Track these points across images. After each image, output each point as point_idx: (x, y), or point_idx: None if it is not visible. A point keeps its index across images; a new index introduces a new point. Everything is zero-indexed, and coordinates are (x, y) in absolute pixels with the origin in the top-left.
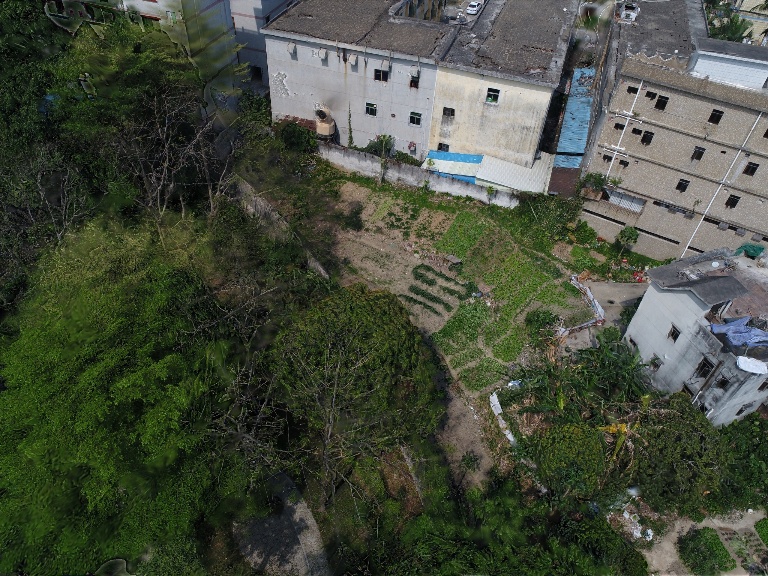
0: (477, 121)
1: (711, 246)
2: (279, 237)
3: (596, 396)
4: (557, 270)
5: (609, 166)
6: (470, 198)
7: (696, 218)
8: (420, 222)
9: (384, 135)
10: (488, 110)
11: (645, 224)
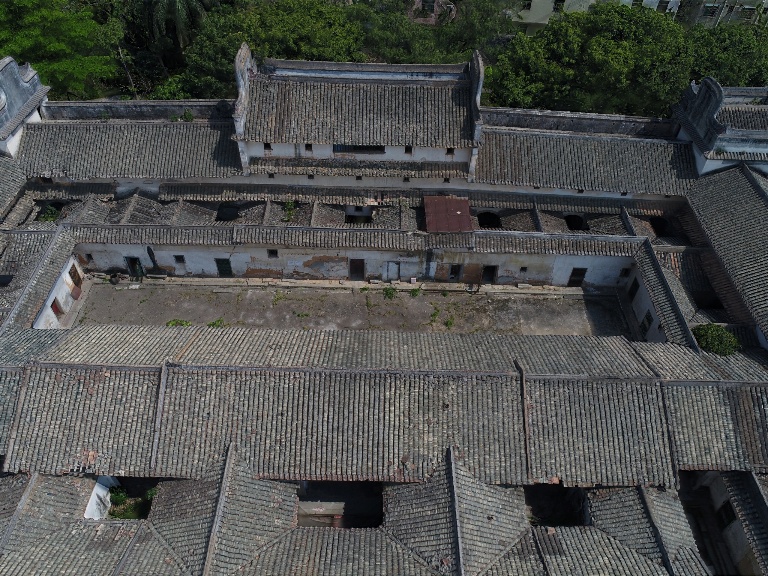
0: None
1: None
2: None
3: None
4: None
5: None
6: None
7: None
8: None
9: None
10: None
11: None
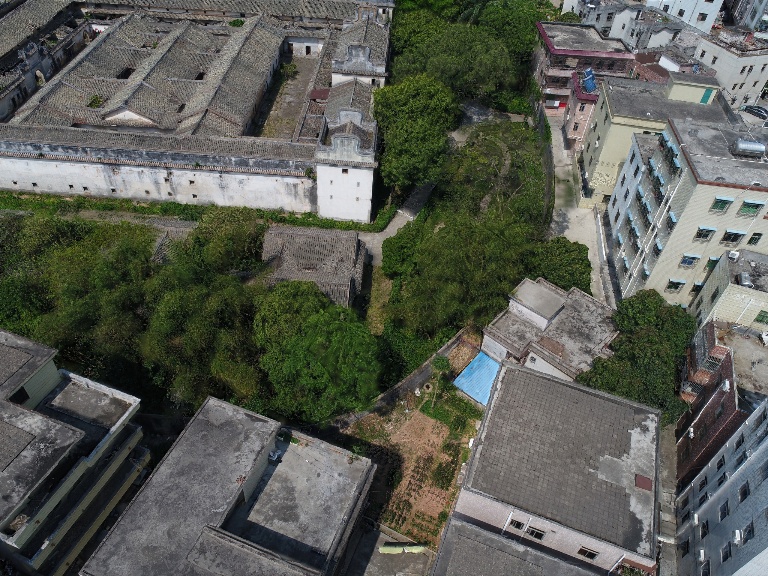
0: None
1: None
2: None
3: None
4: None
5: None
6: None
7: None
8: None
9: None
10: None
11: None
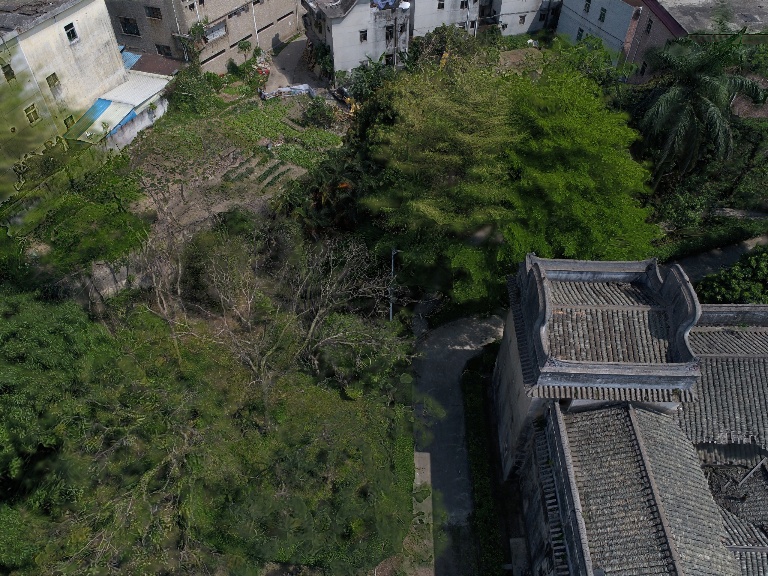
0: (75, 69)
1: (264, 20)
2: (181, 253)
3: (407, 76)
4: (252, 102)
5: (196, 12)
6: (141, 132)
7: (250, 7)
8: (161, 171)
9: (57, 137)
10: (76, 50)
11: (233, 38)
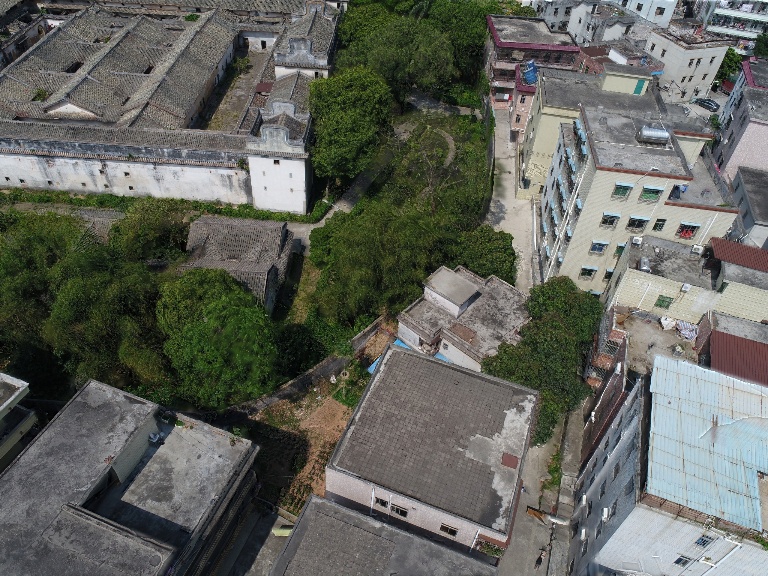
0: None
1: None
2: None
3: None
4: None
5: None
6: None
7: None
8: None
9: None
10: None
11: None
